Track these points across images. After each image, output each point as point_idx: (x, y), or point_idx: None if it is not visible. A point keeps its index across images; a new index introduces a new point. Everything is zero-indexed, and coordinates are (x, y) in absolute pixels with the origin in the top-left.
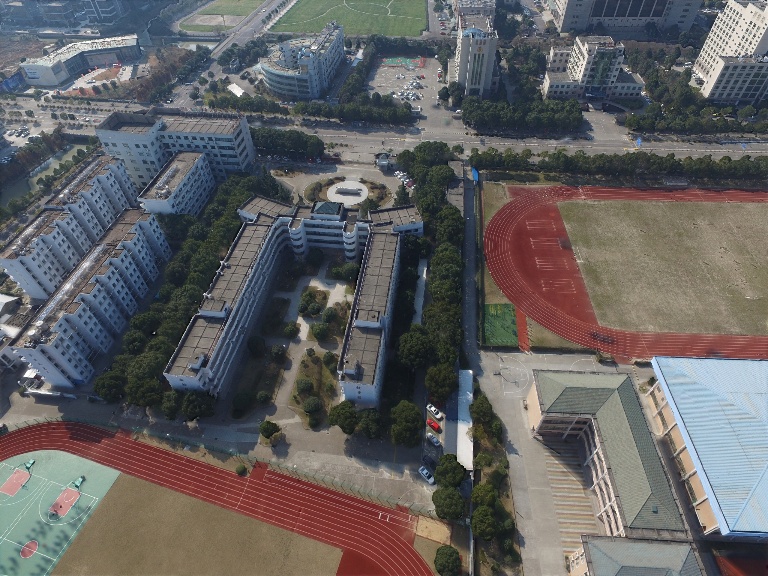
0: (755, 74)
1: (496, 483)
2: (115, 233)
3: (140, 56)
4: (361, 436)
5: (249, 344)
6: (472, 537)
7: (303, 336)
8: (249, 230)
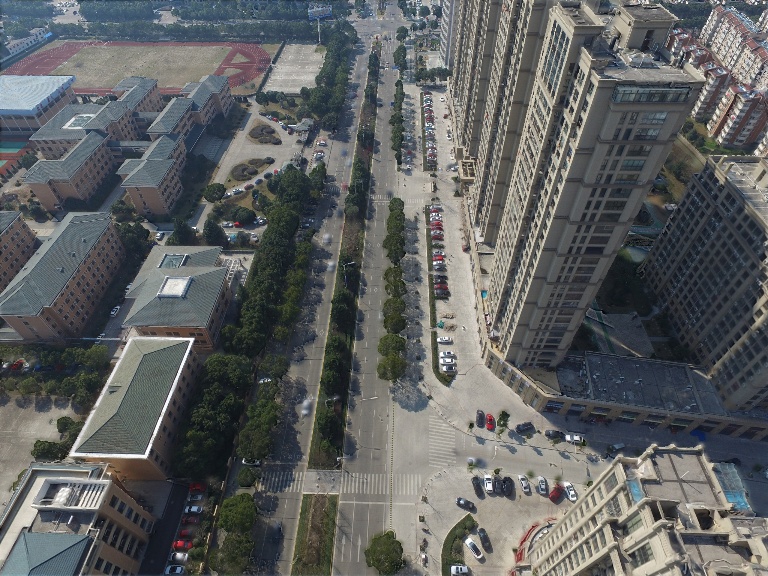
0: None
1: None
2: None
3: None
4: None
5: None
6: None
7: None
8: None
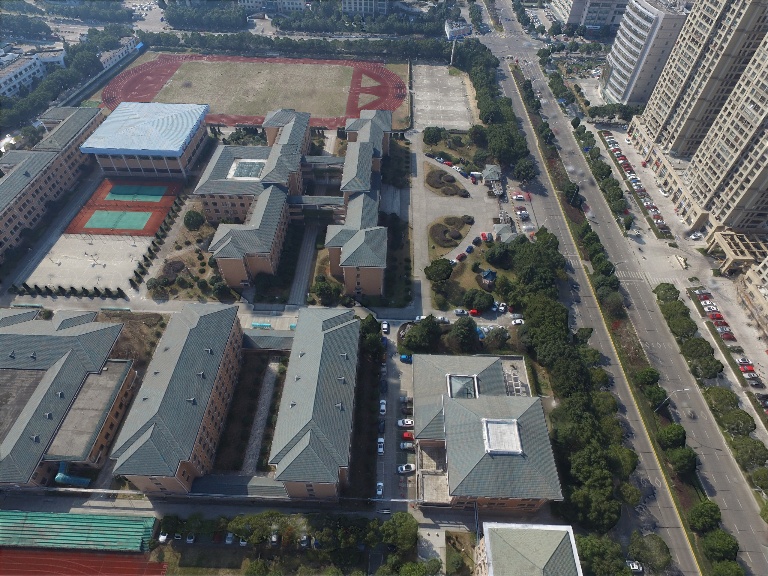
0: None
1: None
2: None
3: None
4: None
5: None
6: None
7: None
8: None
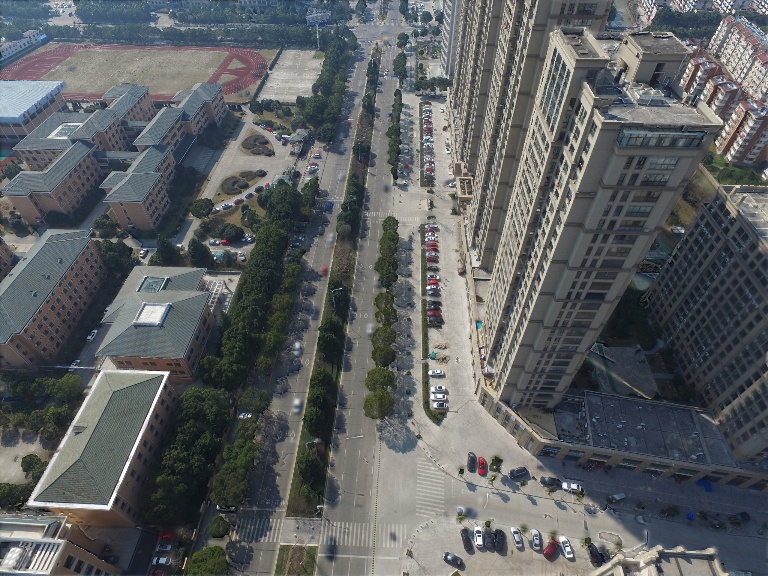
0: None
1: None
2: None
3: None
4: None
5: None
6: None
7: None
8: None
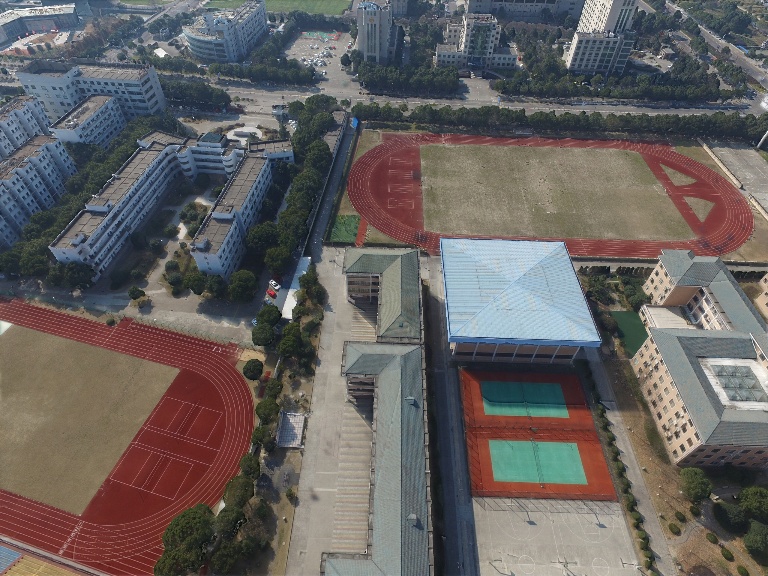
0: (605, 48)
1: (309, 328)
2: (23, 151)
3: (78, 24)
4: (212, 301)
5: (131, 238)
6: (279, 358)
7: (181, 236)
8: (142, 154)
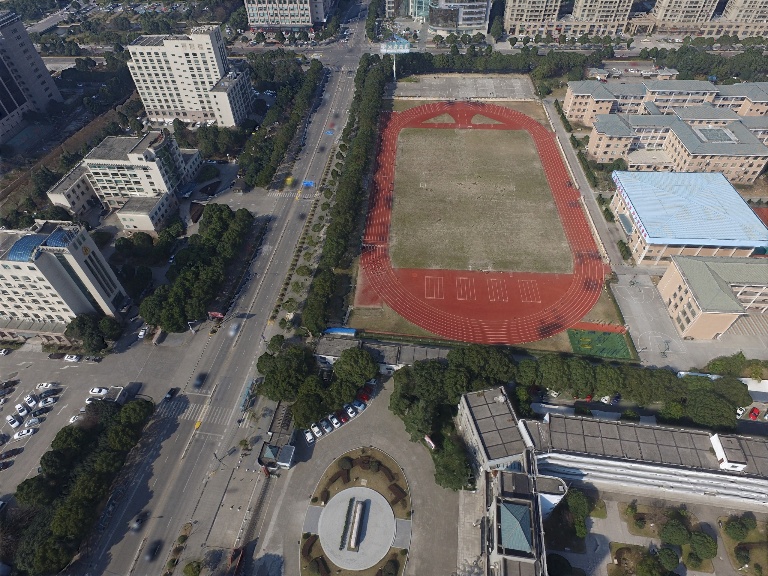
0: (240, 88)
1: None
2: None
3: None
4: None
5: None
6: None
7: None
8: None
